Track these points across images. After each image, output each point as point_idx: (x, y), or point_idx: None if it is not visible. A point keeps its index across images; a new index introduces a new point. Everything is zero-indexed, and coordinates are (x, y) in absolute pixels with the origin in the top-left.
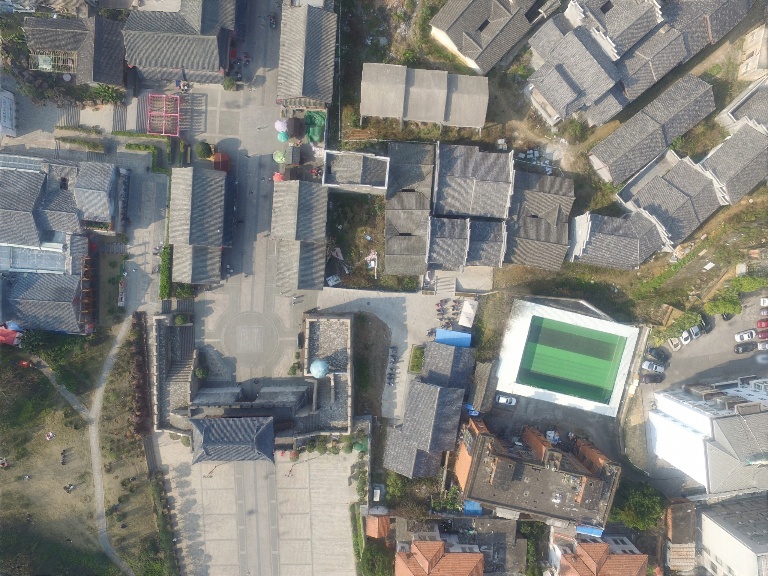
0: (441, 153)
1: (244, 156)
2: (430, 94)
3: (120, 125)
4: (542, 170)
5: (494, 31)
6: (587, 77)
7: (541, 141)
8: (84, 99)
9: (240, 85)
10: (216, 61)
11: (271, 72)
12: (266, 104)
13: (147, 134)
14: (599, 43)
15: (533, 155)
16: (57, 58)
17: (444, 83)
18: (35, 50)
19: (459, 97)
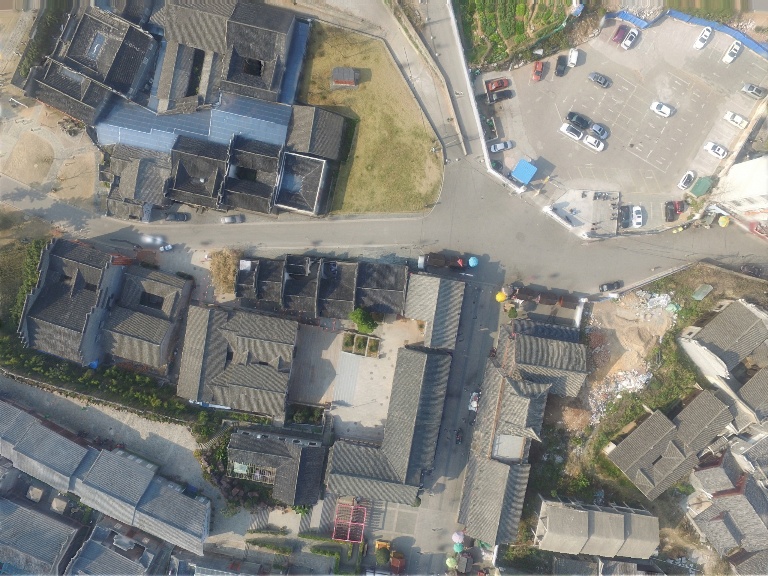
0: (603, 571)
1: (417, 553)
2: (608, 541)
3: (305, 524)
4: (686, 571)
5: (667, 469)
6: (750, 528)
7: (689, 547)
8: (275, 502)
9: (421, 491)
10: (413, 499)
11: (451, 481)
12: (443, 509)
13: (332, 540)
14: (763, 491)
15: (681, 561)
16: (254, 468)
17: (621, 531)
18: (234, 460)
19: (632, 541)
